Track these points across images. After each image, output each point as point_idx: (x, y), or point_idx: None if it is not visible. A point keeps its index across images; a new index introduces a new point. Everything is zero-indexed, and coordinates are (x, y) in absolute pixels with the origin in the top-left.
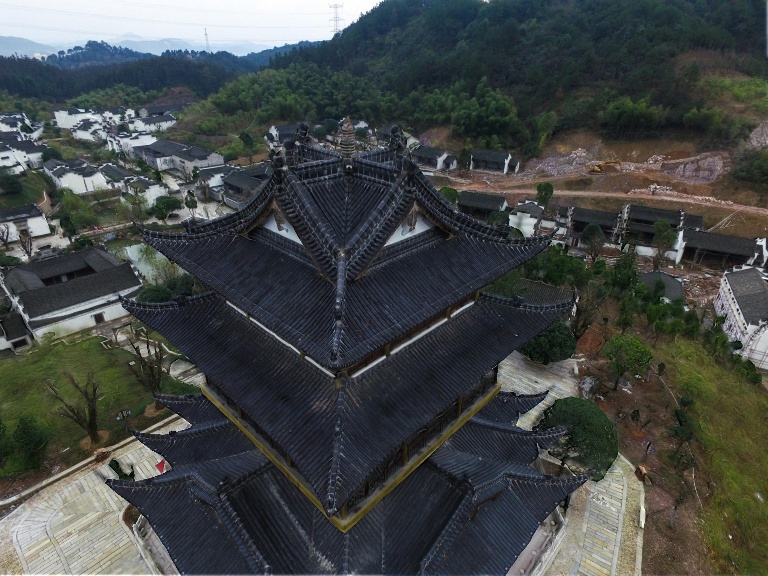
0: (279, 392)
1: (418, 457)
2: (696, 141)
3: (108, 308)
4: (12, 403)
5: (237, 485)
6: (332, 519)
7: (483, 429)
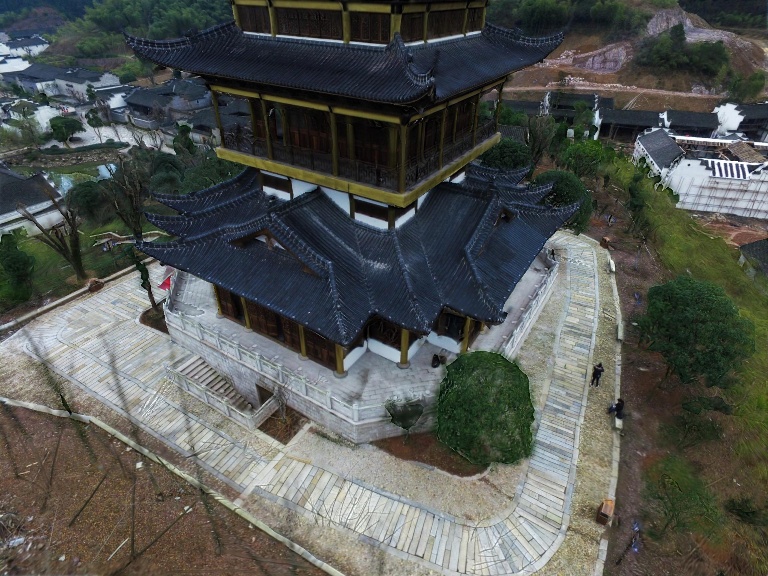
0: (332, 70)
1: (449, 166)
2: (602, 34)
3: (27, 222)
4: None
5: (283, 210)
6: (391, 198)
7: (484, 187)
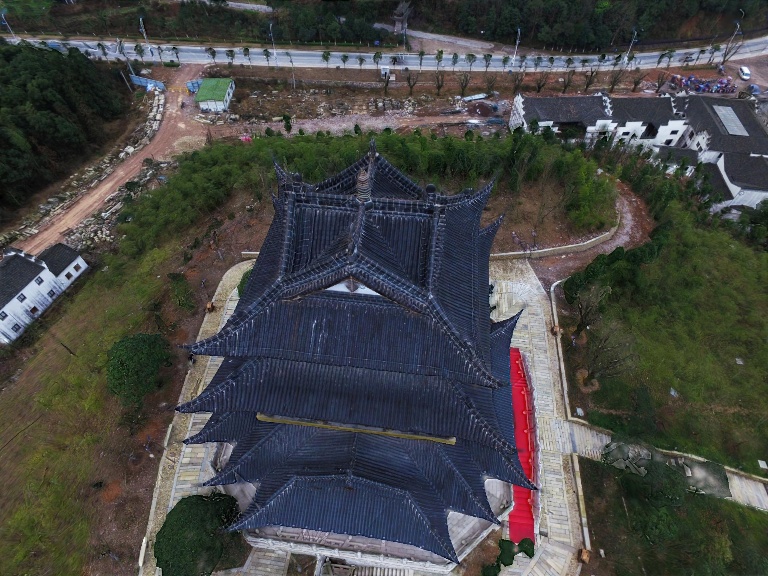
0: None
1: None
2: None
3: None
4: (684, 327)
5: None
6: None
7: None
